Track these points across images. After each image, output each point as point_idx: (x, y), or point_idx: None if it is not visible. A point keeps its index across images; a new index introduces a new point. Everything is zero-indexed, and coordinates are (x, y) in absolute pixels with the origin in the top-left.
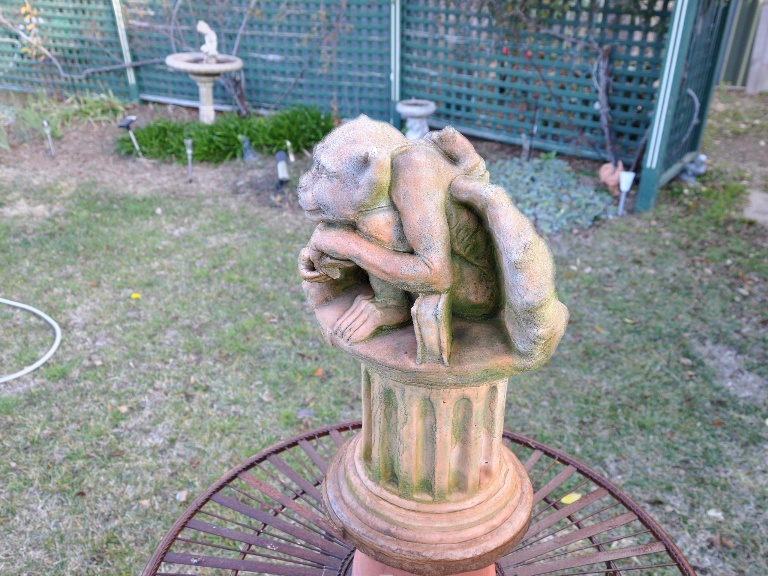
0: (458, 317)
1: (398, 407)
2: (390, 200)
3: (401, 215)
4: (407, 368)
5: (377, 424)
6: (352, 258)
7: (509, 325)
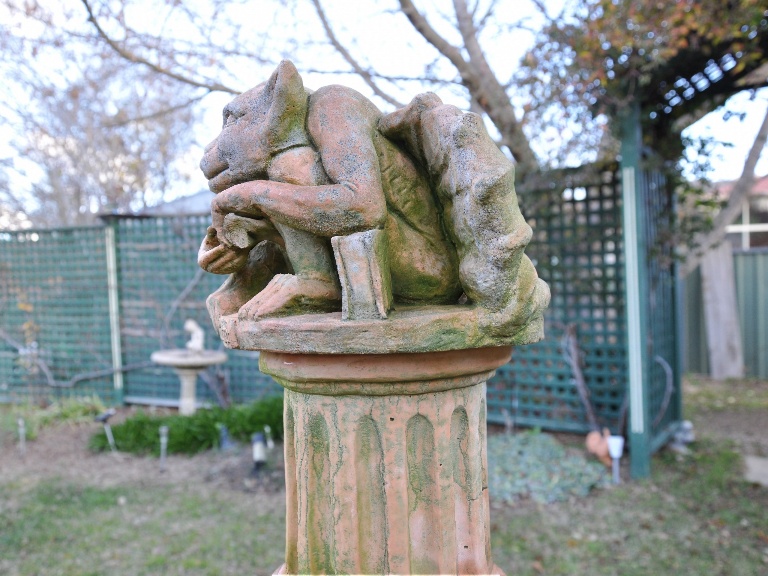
0: (403, 304)
1: (329, 438)
2: (307, 138)
3: (320, 148)
4: (329, 323)
5: (303, 482)
6: (260, 199)
7: (463, 265)
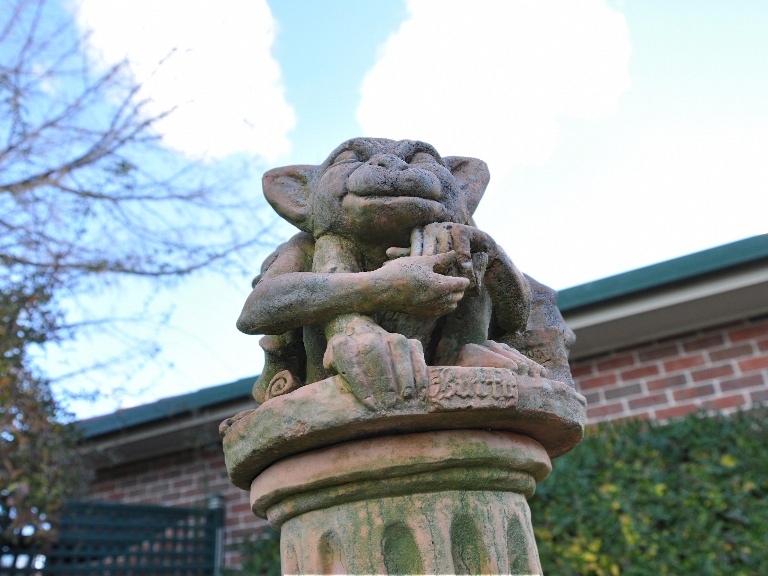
0: None
1: (528, 545)
2: None
3: None
4: None
5: None
6: (505, 258)
7: None
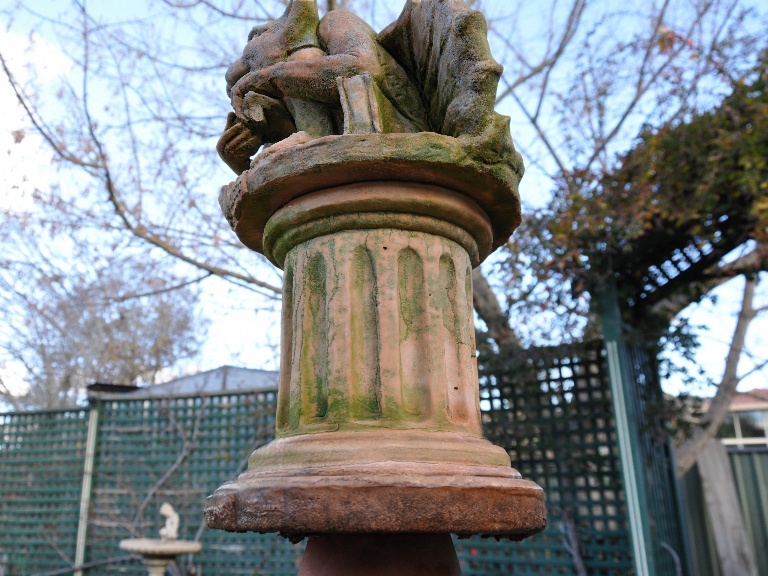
0: None
1: (326, 271)
2: (318, 42)
3: (328, 44)
4: None
5: (299, 321)
6: (276, 72)
7: None
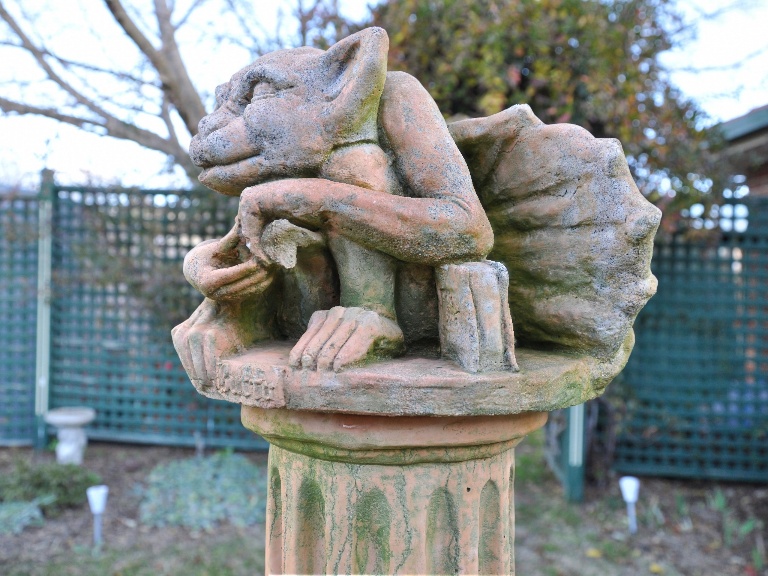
0: None
1: (391, 521)
2: (377, 133)
3: (400, 149)
4: (462, 378)
5: None
6: (338, 206)
7: (570, 308)
